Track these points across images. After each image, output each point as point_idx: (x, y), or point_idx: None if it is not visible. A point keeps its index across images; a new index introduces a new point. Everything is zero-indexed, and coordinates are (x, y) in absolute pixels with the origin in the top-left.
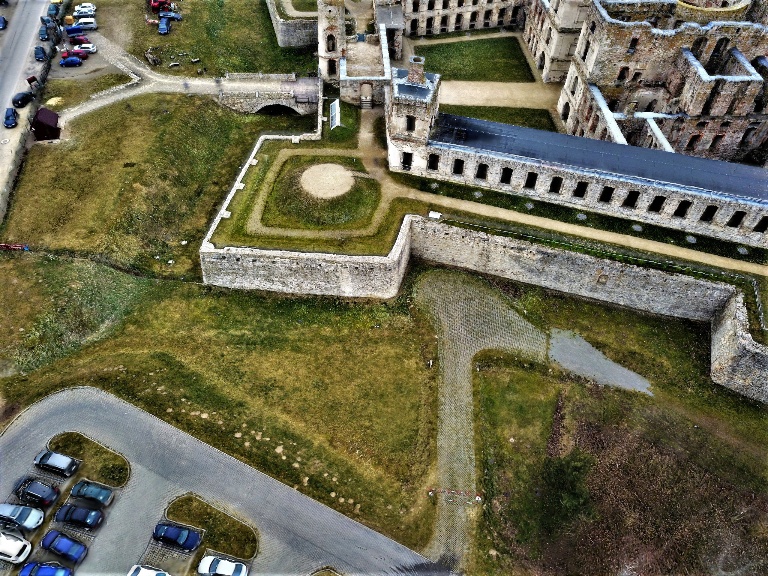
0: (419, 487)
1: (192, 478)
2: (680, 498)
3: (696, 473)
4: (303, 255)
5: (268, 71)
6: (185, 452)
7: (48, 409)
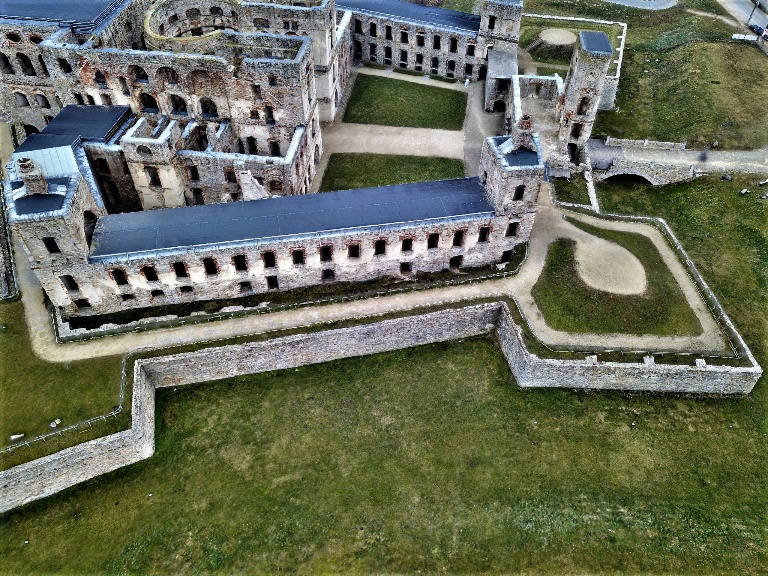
0: None
1: None
2: None
3: None
4: (565, 17)
5: (653, 214)
6: None
7: None
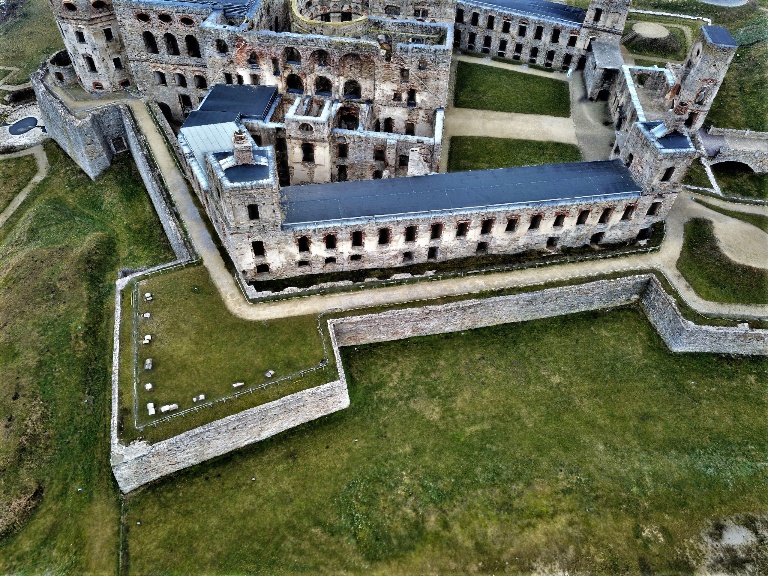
0: None
1: None
2: None
3: None
4: (651, 11)
5: None
6: None
7: None
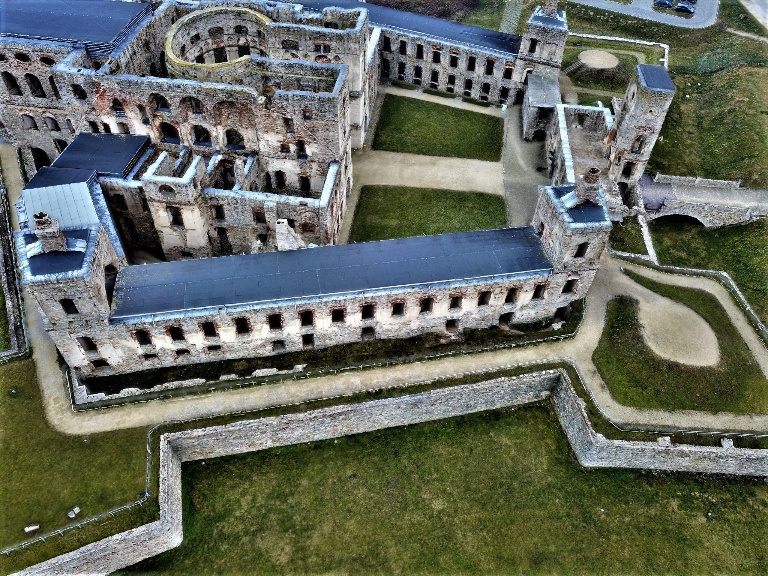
0: (530, 5)
1: (626, 7)
2: (419, 1)
3: (404, 8)
4: (603, 36)
5: (708, 261)
6: (633, 12)
7: (703, 24)
